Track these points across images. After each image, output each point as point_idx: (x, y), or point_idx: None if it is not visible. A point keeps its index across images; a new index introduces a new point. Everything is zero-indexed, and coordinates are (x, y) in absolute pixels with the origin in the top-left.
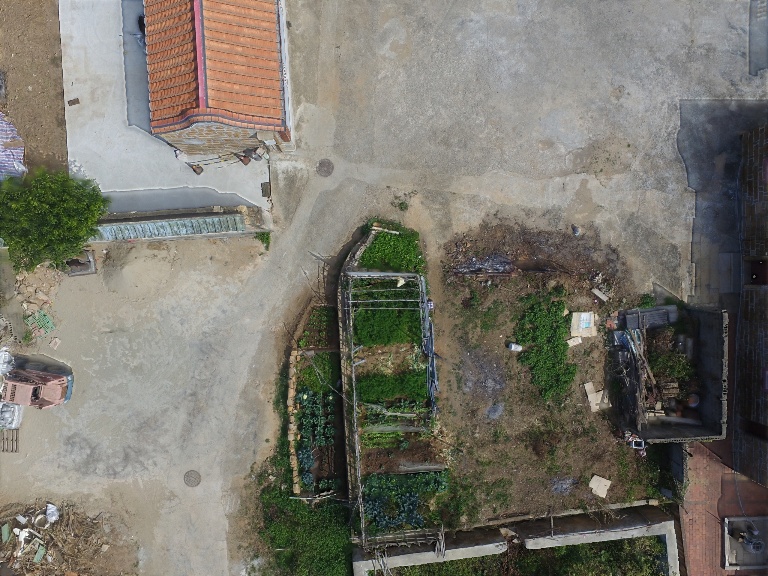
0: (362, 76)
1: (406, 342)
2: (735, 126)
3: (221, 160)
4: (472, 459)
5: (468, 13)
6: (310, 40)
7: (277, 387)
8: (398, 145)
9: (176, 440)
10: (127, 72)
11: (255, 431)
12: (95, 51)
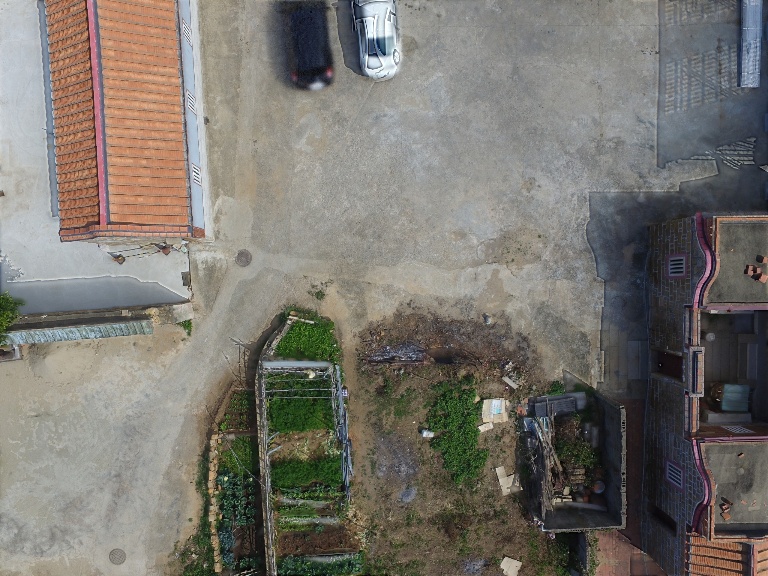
0: (278, 170)
1: (322, 428)
2: (643, 217)
3: (142, 250)
4: (386, 541)
5: (382, 108)
6: (227, 135)
7: (200, 468)
8: (314, 236)
9: (101, 519)
10: (51, 165)
11: (178, 511)
12: (19, 144)
